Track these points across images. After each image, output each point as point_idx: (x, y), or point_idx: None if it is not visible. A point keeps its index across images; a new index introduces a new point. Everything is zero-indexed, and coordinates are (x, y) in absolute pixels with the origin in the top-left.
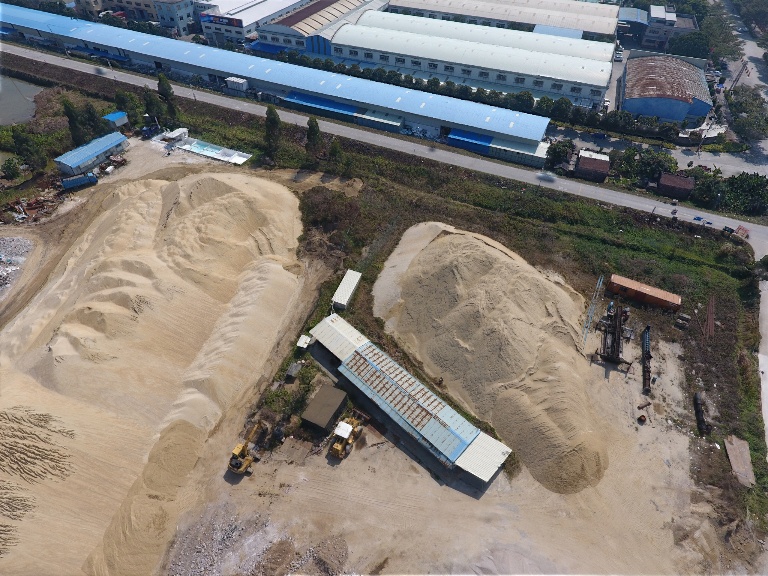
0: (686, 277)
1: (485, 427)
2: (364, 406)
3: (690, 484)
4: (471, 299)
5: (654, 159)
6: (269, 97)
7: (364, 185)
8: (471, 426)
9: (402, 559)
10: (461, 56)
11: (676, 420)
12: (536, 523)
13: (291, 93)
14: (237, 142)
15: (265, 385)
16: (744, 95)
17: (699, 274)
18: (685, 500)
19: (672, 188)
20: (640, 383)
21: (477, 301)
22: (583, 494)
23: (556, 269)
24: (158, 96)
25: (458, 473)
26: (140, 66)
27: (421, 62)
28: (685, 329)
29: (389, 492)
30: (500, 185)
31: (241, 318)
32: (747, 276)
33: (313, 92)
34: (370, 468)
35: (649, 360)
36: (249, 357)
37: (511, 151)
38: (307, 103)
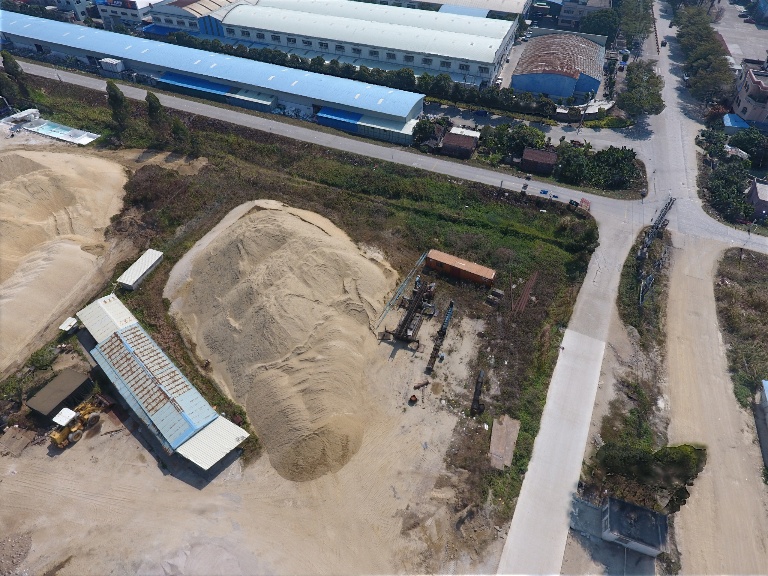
0: (514, 252)
1: (233, 411)
2: (112, 391)
3: (441, 468)
4: (251, 275)
5: (518, 133)
6: (146, 79)
7: (207, 164)
8: (210, 410)
9: (88, 557)
10: (351, 34)
11: (450, 400)
12: (255, 514)
13: (166, 74)
14: (88, 122)
15: (13, 371)
16: (637, 71)
17: (529, 248)
18: (429, 485)
19: (535, 163)
20: (426, 362)
21: (253, 277)
22: (319, 481)
23: (380, 246)
24: (7, 75)
25: (189, 461)
26: (21, 49)
27: (312, 42)
28: (494, 305)
29: (103, 484)
30: (353, 162)
31: (4, 300)
32: (579, 250)
33: (186, 72)
34: (93, 458)
35: (441, 337)
36: (3, 342)
37: (378, 128)
38: (180, 83)
